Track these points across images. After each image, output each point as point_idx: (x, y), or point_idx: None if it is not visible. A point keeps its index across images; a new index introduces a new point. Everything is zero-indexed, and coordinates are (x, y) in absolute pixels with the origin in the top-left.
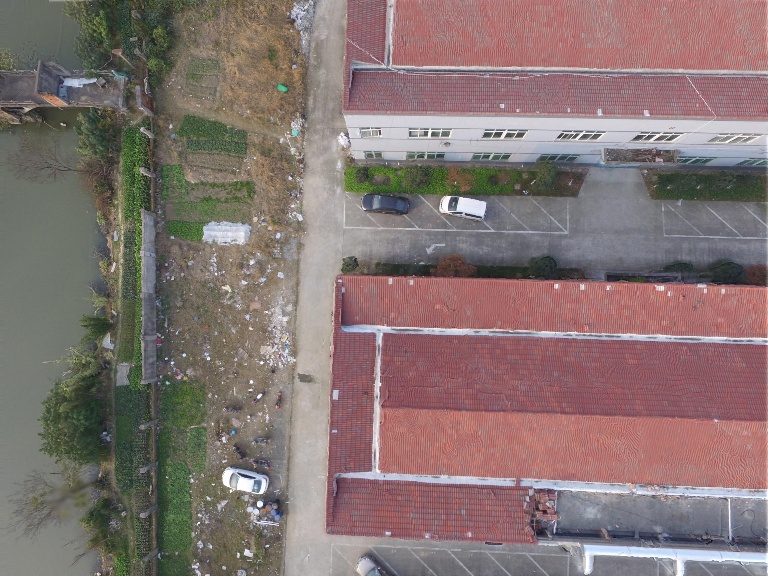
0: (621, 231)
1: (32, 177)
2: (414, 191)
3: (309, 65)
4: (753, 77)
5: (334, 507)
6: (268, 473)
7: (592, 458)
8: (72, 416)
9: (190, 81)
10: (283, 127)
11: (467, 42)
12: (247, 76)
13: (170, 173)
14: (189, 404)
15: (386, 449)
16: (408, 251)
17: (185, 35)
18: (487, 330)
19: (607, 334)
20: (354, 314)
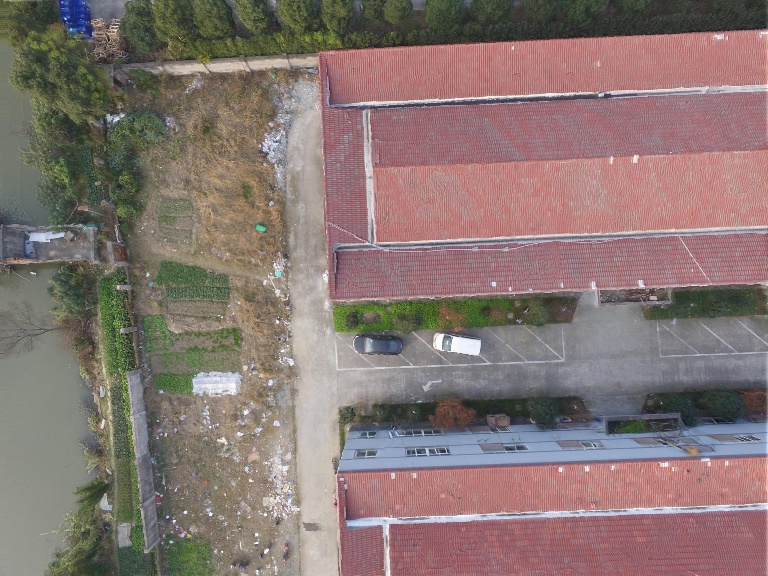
0: (617, 355)
1: (8, 348)
2: None
3: (286, 200)
4: (746, 233)
5: None
6: None
7: None
8: None
9: (163, 224)
10: (265, 268)
11: (452, 202)
12: (223, 217)
13: (152, 324)
14: (195, 562)
15: None
16: (404, 390)
17: (153, 175)
18: (494, 514)
19: (614, 509)
20: (359, 508)
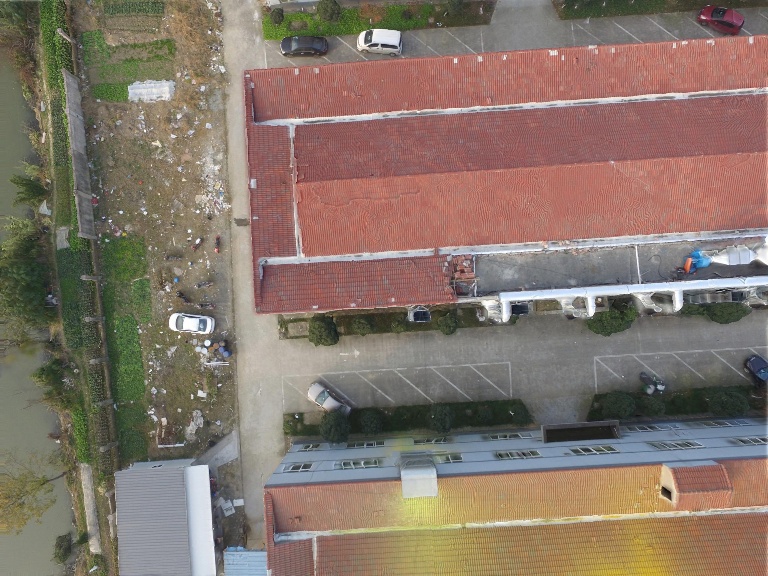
0: None
1: None
2: (331, 33)
3: None
4: None
5: (261, 288)
6: (214, 316)
7: (503, 217)
8: (12, 271)
9: None
10: None
11: None
12: None
13: (90, 39)
14: (130, 258)
15: (309, 235)
16: None
17: None
18: (395, 113)
19: (509, 105)
20: (266, 109)
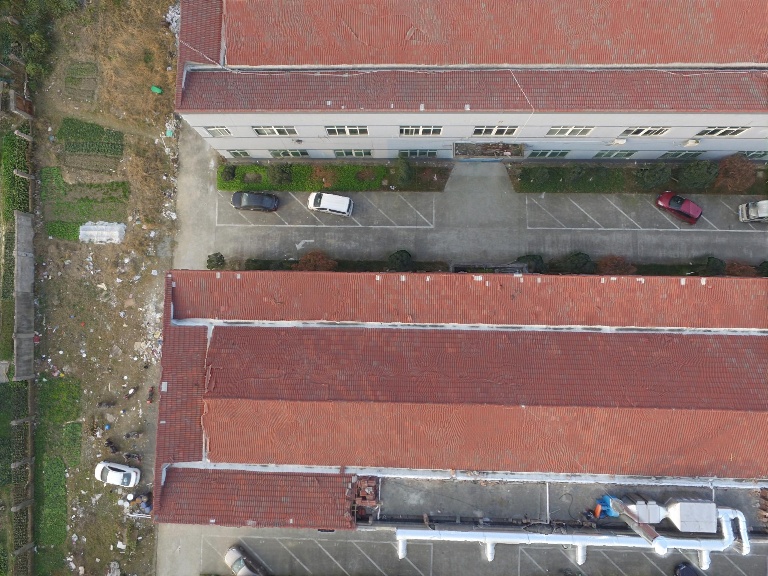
0: (485, 224)
1: None
2: (284, 188)
3: None
4: (575, 70)
5: (161, 496)
6: (141, 467)
7: (411, 445)
8: None
9: (69, 84)
10: (158, 128)
11: None
12: (123, 79)
13: (49, 175)
14: (65, 400)
15: (217, 439)
16: (278, 247)
17: (64, 40)
18: (315, 322)
19: (430, 324)
20: (186, 308)
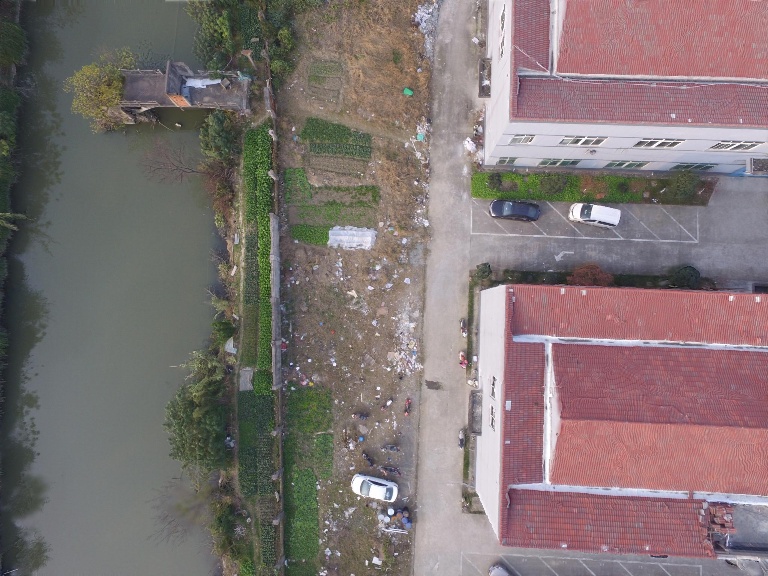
0: (751, 241)
1: (160, 179)
2: (542, 198)
3: (434, 69)
4: None
5: (508, 519)
6: (396, 480)
7: None
8: (205, 422)
9: (312, 83)
10: (408, 131)
11: (624, 50)
12: (372, 79)
13: (293, 176)
14: (315, 410)
15: (556, 460)
16: (536, 258)
17: (307, 36)
18: (657, 342)
19: None
20: (523, 324)
